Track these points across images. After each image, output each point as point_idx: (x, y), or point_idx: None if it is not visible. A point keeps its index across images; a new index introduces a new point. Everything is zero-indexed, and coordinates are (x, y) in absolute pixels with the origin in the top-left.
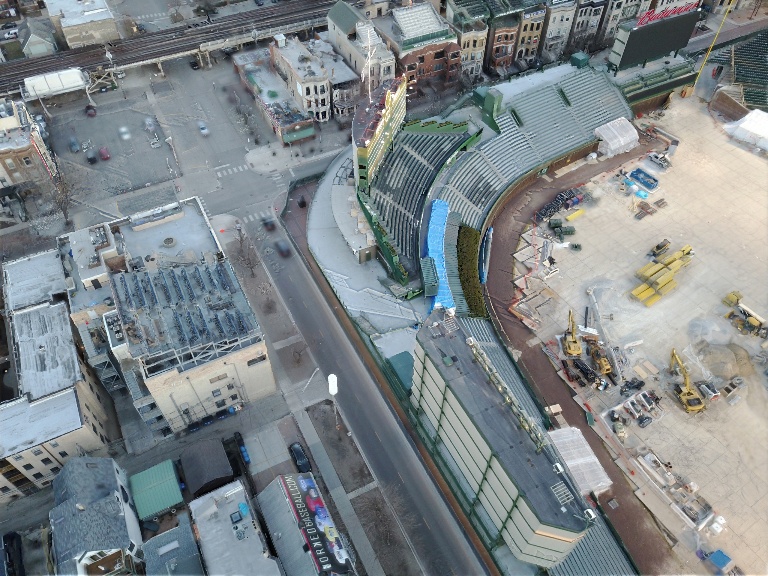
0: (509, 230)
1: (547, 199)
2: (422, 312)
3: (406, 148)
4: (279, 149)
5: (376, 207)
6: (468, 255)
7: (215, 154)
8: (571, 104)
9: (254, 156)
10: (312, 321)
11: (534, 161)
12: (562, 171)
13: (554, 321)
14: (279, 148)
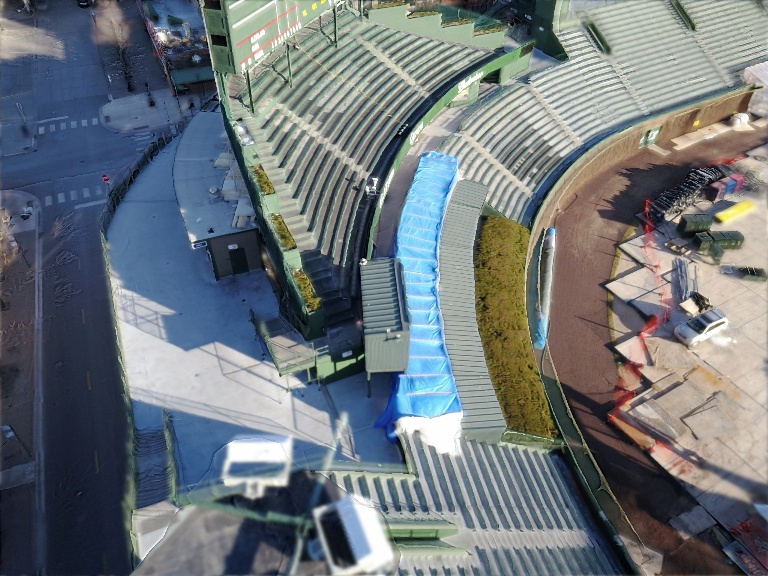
0: (591, 235)
1: (665, 183)
2: (358, 421)
3: (369, 48)
4: (165, 98)
5: (267, 136)
6: (501, 275)
7: (51, 102)
8: (696, 26)
9: (117, 106)
10: (86, 425)
11: (633, 113)
12: (686, 139)
13: (741, 459)
14: (165, 97)
